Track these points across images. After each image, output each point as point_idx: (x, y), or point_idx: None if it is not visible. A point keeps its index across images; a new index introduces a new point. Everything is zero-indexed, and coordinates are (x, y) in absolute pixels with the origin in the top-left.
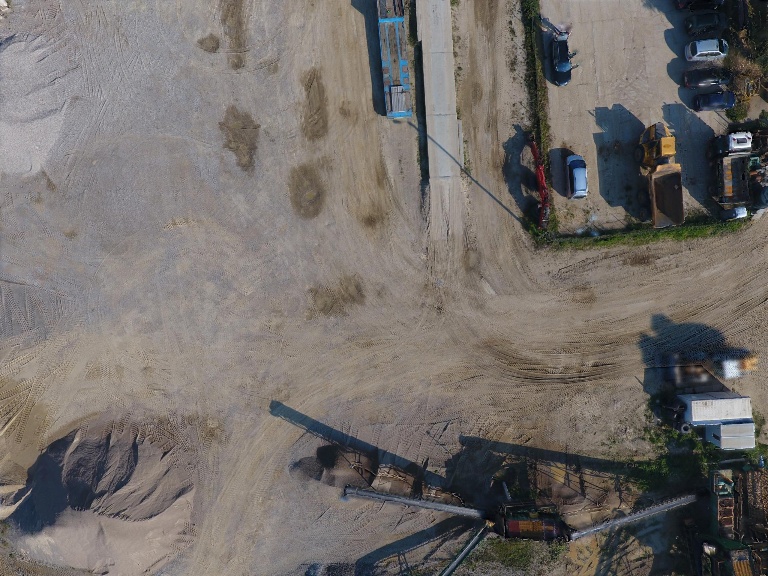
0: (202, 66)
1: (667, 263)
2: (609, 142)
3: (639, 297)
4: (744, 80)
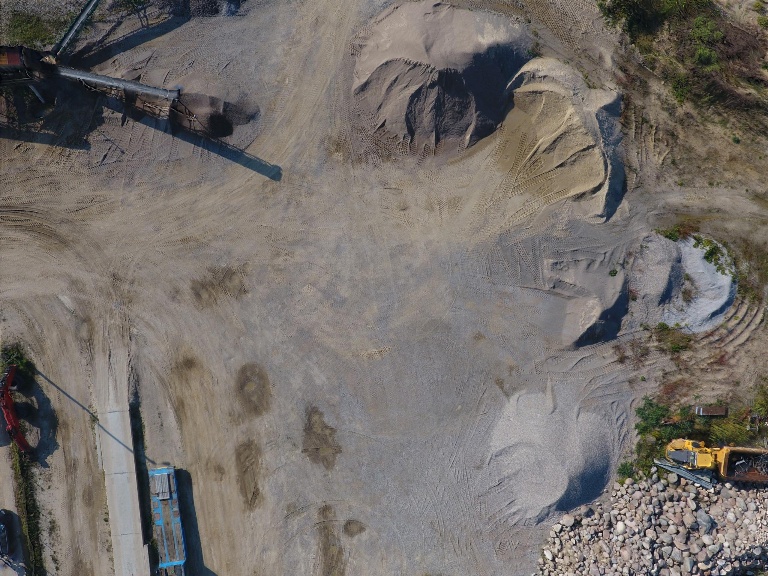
0: (360, 506)
1: None
2: None
3: None
4: None
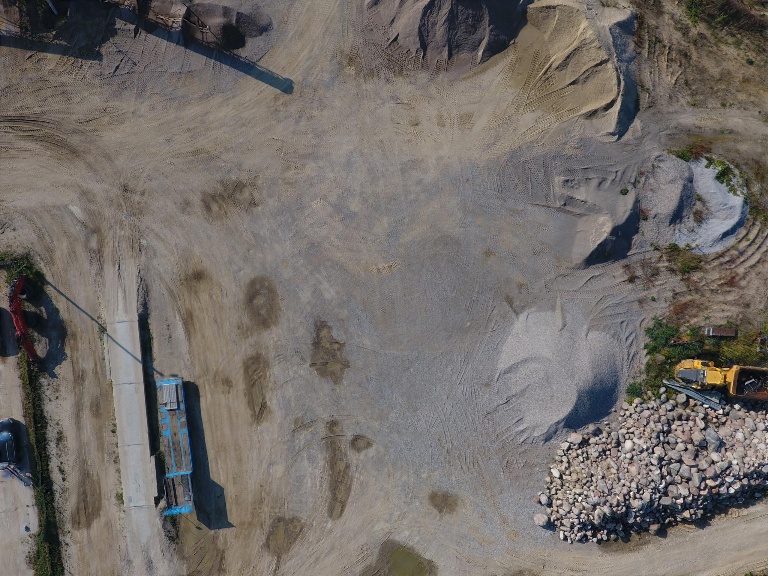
0: (367, 422)
1: None
2: None
3: None
4: None
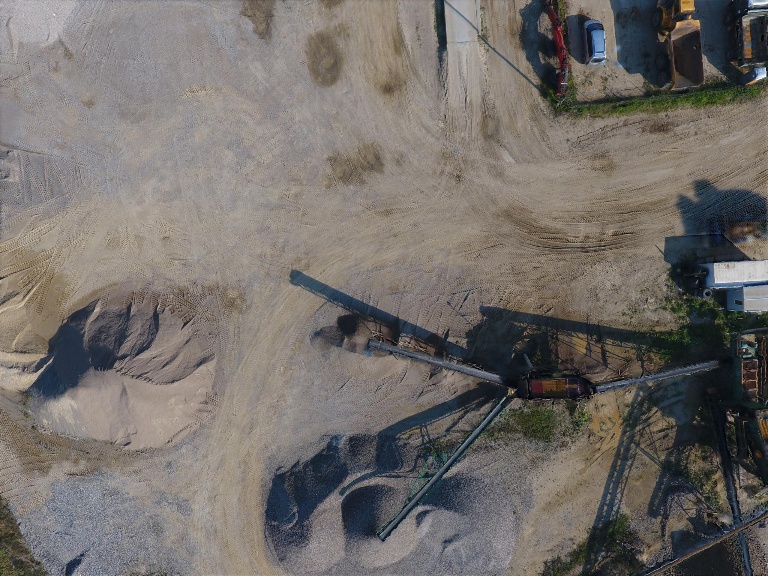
0: None
1: (686, 130)
2: (626, 8)
3: (658, 165)
4: None
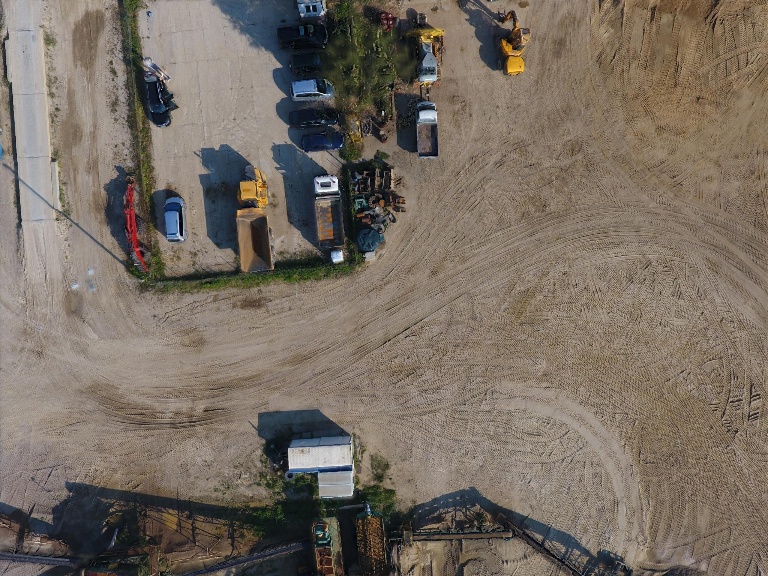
0: None
1: (279, 306)
2: (216, 183)
3: (250, 341)
4: (350, 120)
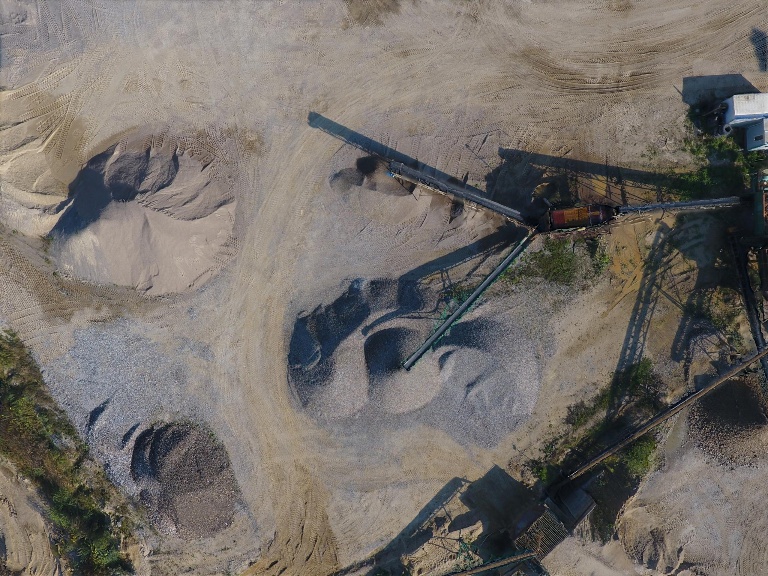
0: None
1: None
2: None
3: (675, 4)
4: None
